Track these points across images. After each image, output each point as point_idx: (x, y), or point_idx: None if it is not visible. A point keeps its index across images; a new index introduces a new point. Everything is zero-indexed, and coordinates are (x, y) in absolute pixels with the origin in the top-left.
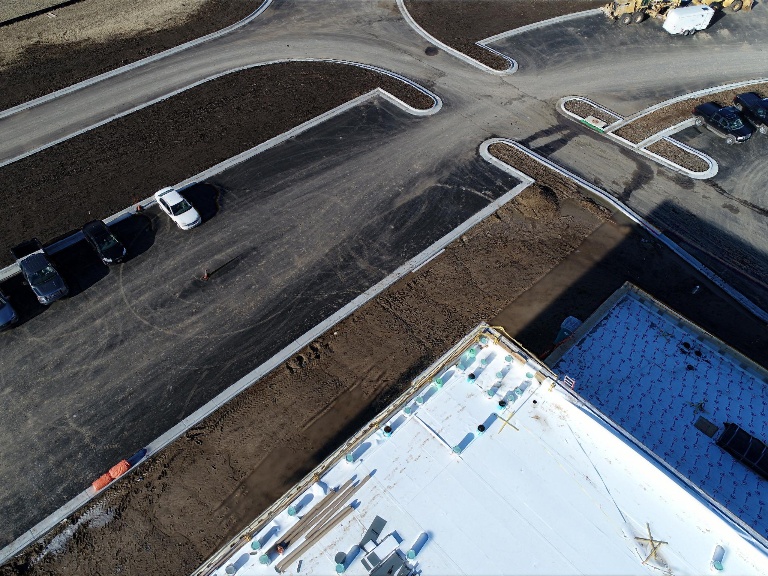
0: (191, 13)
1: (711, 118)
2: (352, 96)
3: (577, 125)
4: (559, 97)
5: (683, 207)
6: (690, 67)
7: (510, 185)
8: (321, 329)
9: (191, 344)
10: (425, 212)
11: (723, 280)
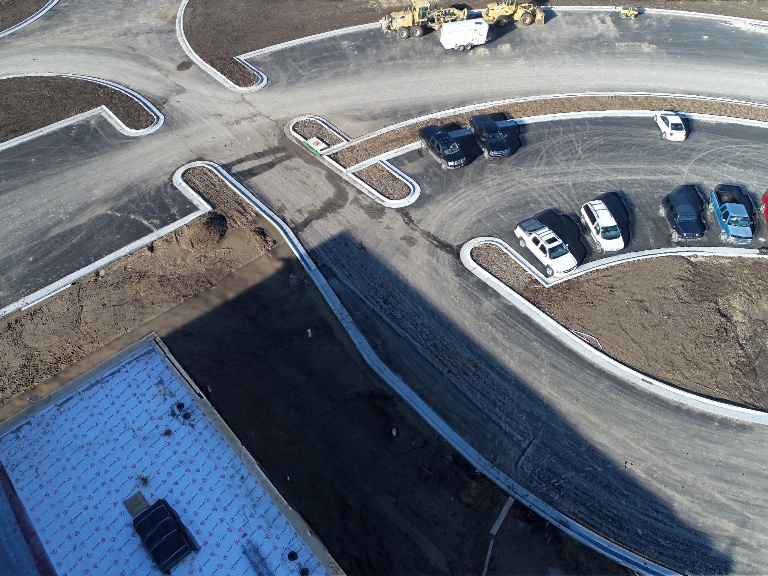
0: None
1: (429, 141)
2: (69, 114)
3: (296, 147)
4: (294, 116)
5: (357, 239)
6: (449, 85)
7: (184, 213)
8: None
9: None
10: (76, 243)
11: (353, 322)
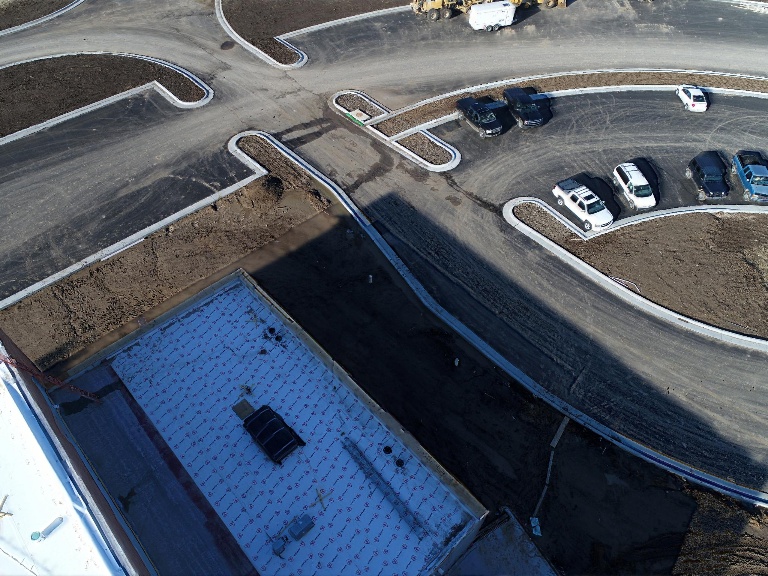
0: (1, 7)
1: (467, 112)
2: (124, 89)
3: (341, 118)
4: (335, 91)
5: (406, 199)
6: (480, 62)
7: (242, 176)
8: None
9: None
10: (144, 202)
11: (409, 270)
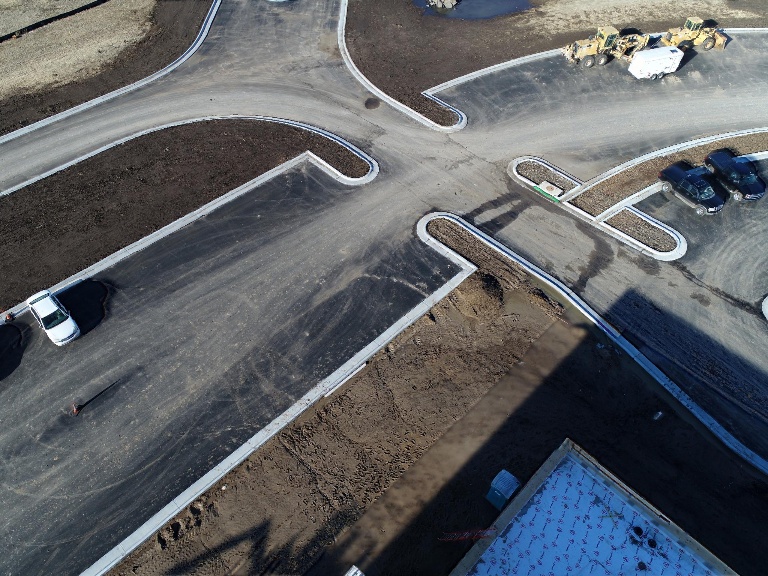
0: (107, 61)
1: (679, 185)
2: (277, 162)
3: (530, 193)
4: (511, 158)
5: (646, 299)
6: (657, 118)
7: (449, 274)
8: (206, 483)
9: (44, 509)
10: (347, 313)
11: (691, 398)
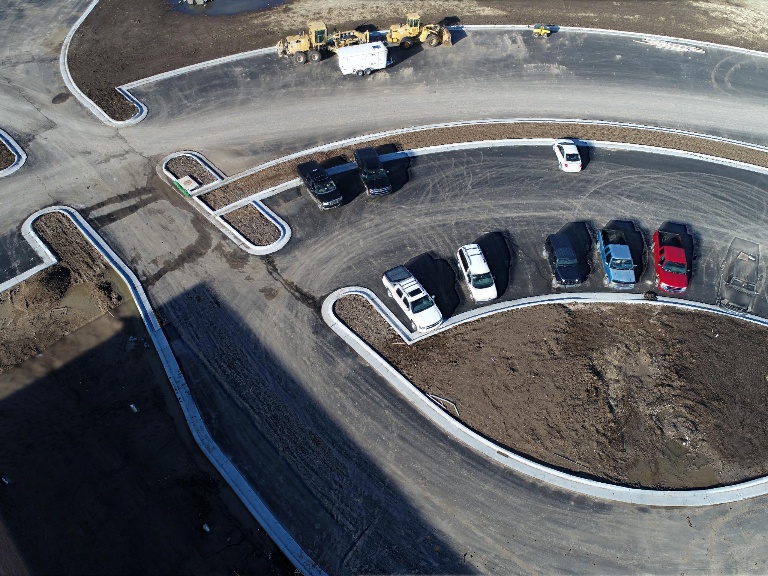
0: None
1: (305, 179)
2: None
3: (166, 187)
4: (169, 152)
5: (213, 292)
6: (342, 114)
7: (26, 267)
8: None
9: None
10: None
11: (189, 391)
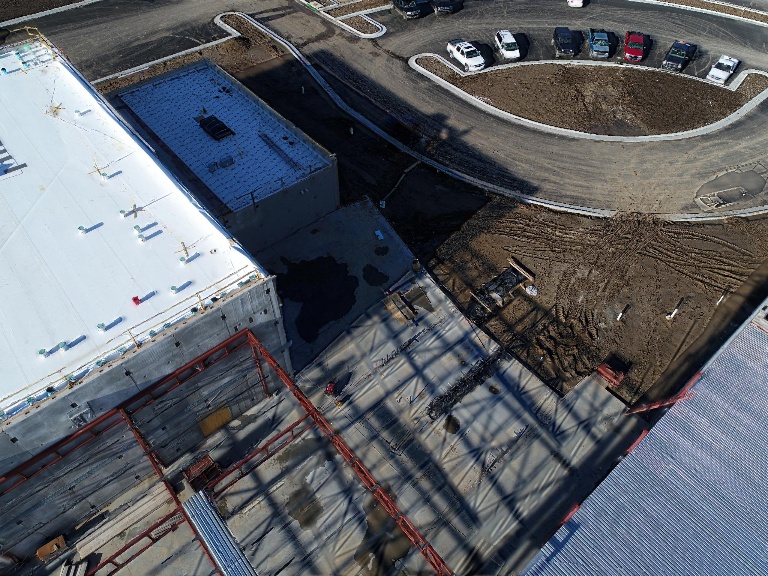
0: None
1: (395, 1)
2: None
3: (301, 7)
4: None
5: (340, 52)
6: None
7: (222, 37)
8: None
9: None
10: (150, 49)
11: (332, 89)
